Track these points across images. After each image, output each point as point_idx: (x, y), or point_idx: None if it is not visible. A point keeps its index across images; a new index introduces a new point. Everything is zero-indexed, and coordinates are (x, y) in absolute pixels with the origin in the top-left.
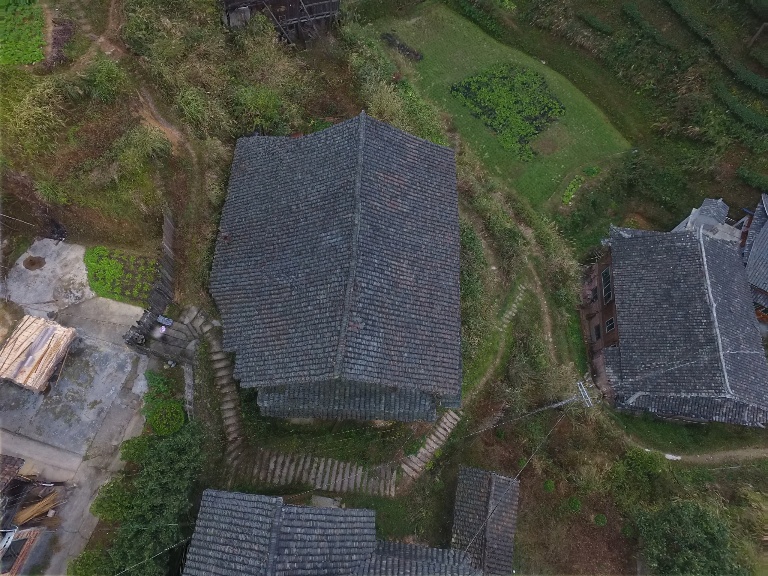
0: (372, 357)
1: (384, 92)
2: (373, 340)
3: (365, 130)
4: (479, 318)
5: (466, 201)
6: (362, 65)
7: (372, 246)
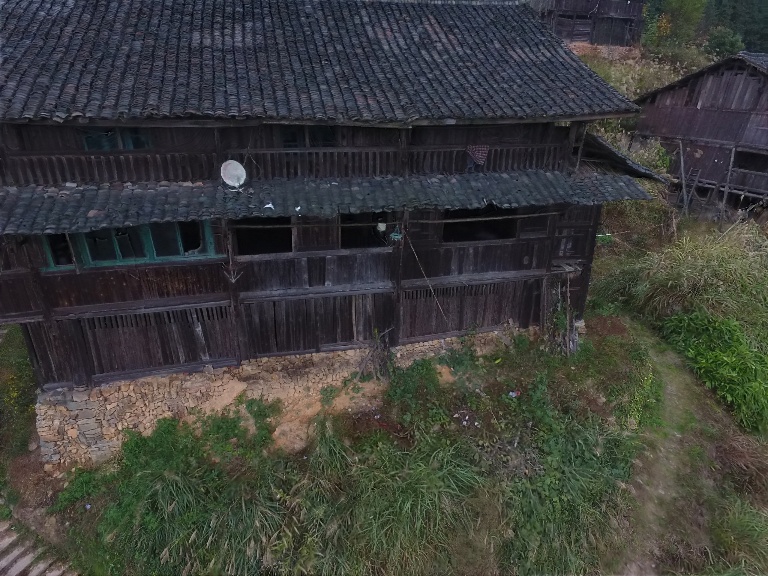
0: (26, 7)
1: (731, 237)
2: (65, 8)
3: (499, 5)
4: (357, 571)
5: (715, 482)
6: (754, 239)
7: (269, 7)
